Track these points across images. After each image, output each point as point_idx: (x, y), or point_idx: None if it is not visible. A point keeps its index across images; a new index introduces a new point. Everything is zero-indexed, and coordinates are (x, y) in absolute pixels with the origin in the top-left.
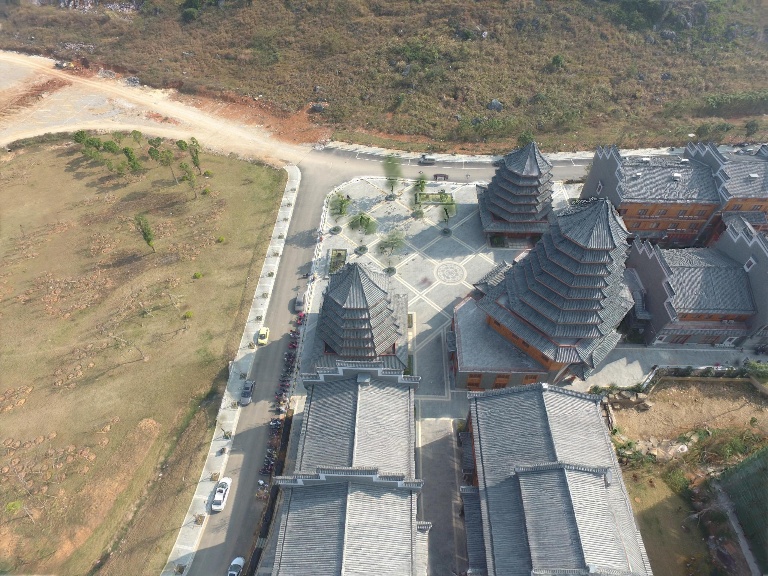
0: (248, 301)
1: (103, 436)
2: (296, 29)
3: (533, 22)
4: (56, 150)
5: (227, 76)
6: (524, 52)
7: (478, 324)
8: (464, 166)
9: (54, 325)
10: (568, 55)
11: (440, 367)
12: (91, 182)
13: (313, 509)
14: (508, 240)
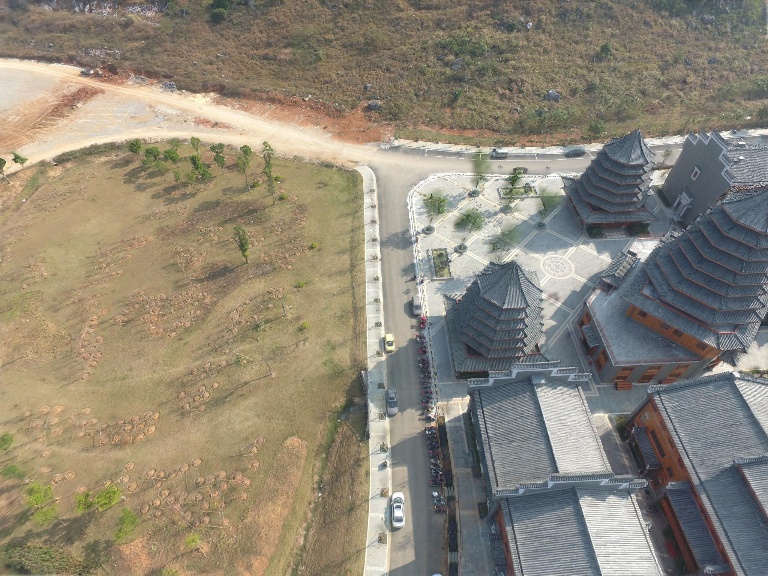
0: (361, 308)
1: (252, 459)
2: (334, 26)
3: (577, 11)
4: (107, 162)
5: (269, 77)
6: (571, 42)
7: (616, 317)
8: (537, 158)
9: (162, 346)
10: (615, 43)
11: (578, 362)
12: (156, 193)
13: (542, 519)
14: (604, 230)
